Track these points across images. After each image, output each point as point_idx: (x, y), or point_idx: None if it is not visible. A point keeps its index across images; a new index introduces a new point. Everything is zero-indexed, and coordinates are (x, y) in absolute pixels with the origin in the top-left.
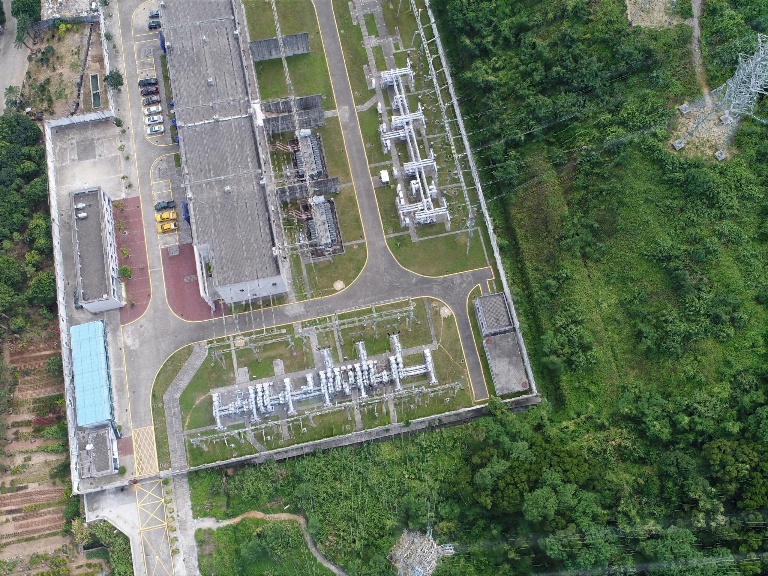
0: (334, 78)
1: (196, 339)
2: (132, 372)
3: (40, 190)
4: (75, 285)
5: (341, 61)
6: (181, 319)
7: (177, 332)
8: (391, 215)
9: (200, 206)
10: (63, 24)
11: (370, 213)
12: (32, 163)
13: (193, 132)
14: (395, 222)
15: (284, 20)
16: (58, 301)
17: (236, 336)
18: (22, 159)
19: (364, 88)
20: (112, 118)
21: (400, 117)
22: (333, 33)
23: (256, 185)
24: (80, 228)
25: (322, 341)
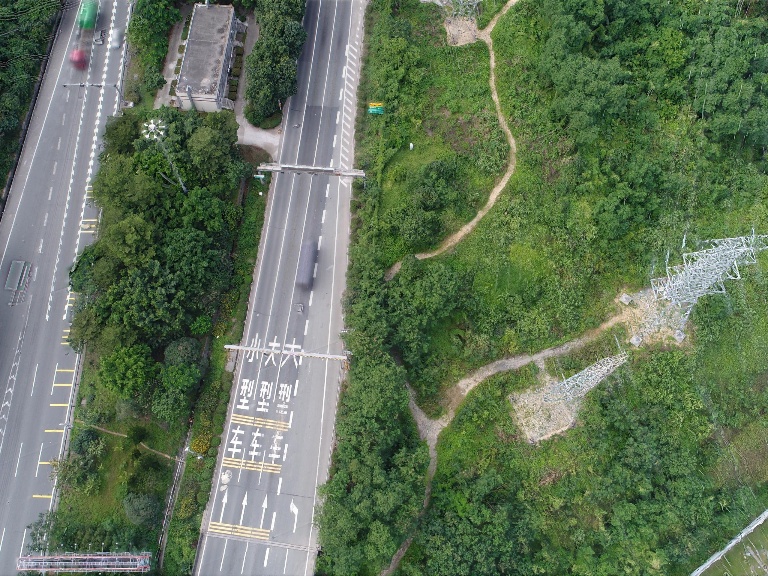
0: None
1: None
2: None
3: None
4: None
5: None
6: None
7: None
8: None
9: None
10: None
11: None
12: None
13: None
14: None
15: None
16: None
17: None
18: None
19: None
20: None
21: None
22: None
23: None
24: None
25: None
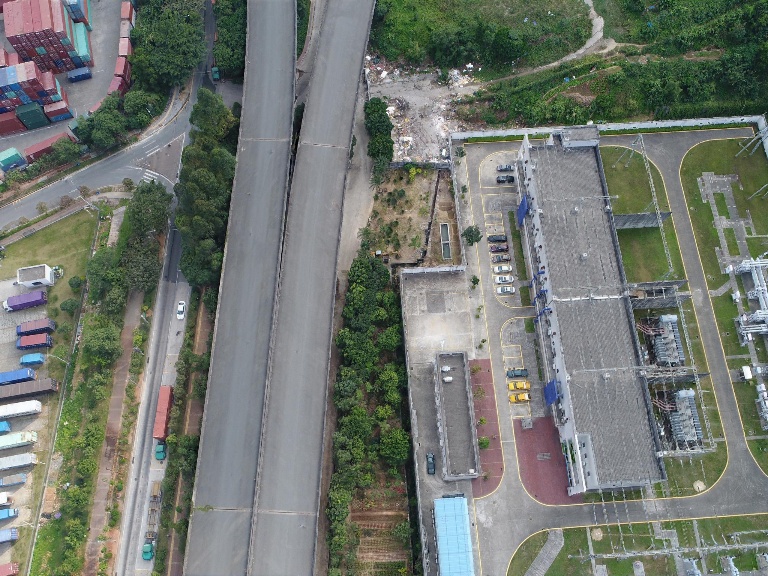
0: (686, 257)
1: (552, 525)
2: (486, 553)
3: (395, 341)
4: (426, 447)
5: (692, 240)
6: (535, 500)
7: (531, 514)
8: (751, 415)
9: (577, 390)
10: (414, 168)
11: (729, 410)
12: (383, 310)
13: (567, 308)
14: (756, 423)
15: (632, 189)
16: (416, 466)
17: (593, 528)
18: (375, 305)
19: (717, 272)
20: (461, 271)
21: (765, 312)
22: (683, 209)
23: (633, 374)
24: (444, 392)
25: (684, 547)
